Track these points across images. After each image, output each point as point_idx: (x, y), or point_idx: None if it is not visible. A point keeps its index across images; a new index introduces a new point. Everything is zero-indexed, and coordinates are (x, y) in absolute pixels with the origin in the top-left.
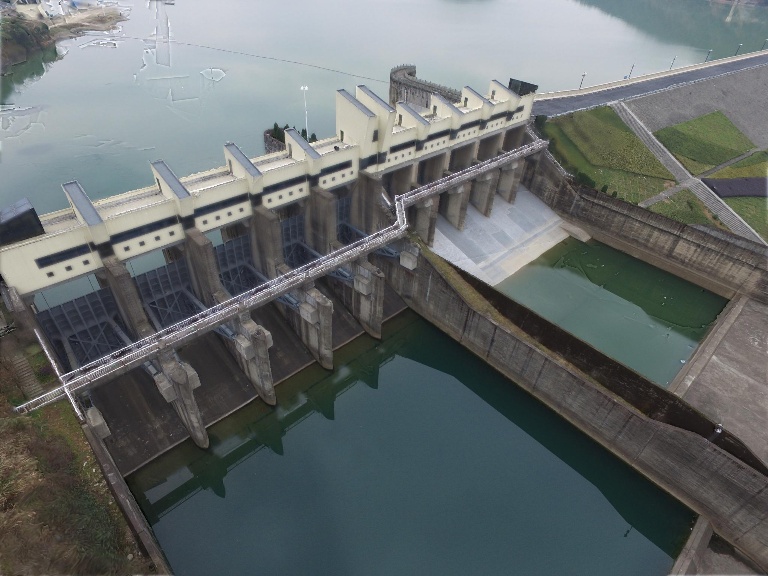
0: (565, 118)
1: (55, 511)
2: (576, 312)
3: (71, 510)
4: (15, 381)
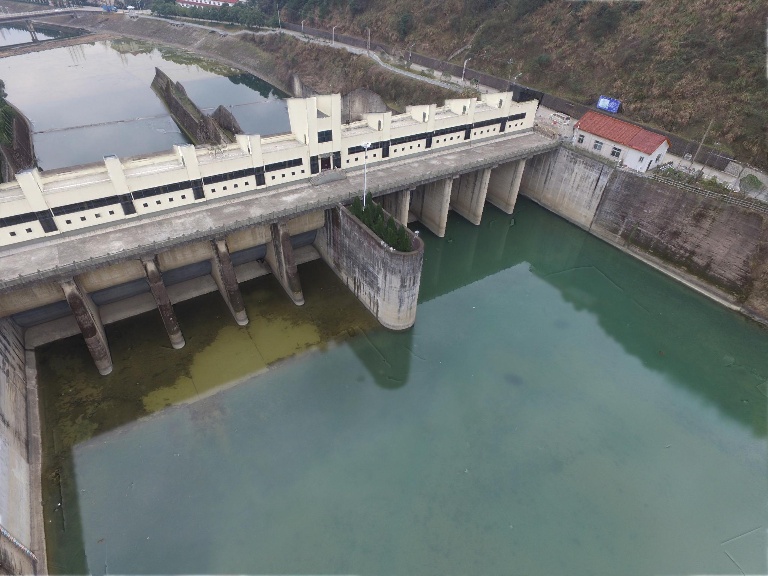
0: None
1: None
2: None
3: None
4: None
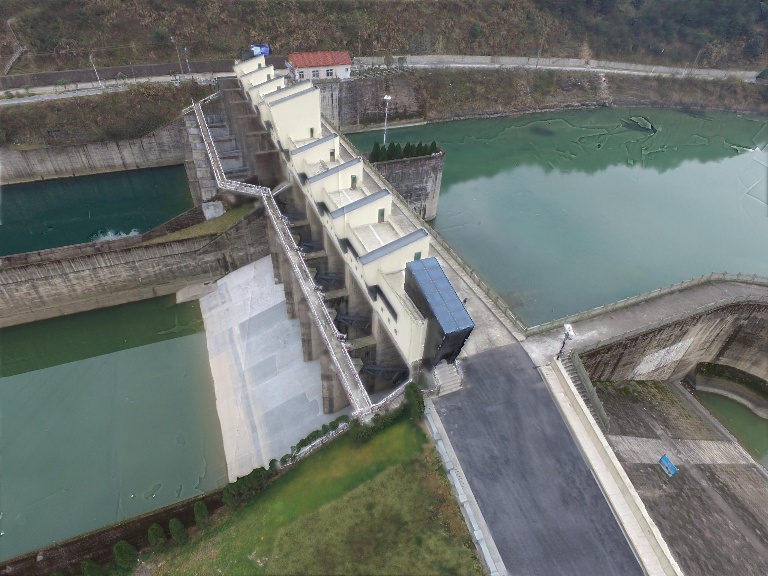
0: (437, 494)
1: (148, 111)
2: (109, 395)
3: (151, 117)
4: (195, 91)
